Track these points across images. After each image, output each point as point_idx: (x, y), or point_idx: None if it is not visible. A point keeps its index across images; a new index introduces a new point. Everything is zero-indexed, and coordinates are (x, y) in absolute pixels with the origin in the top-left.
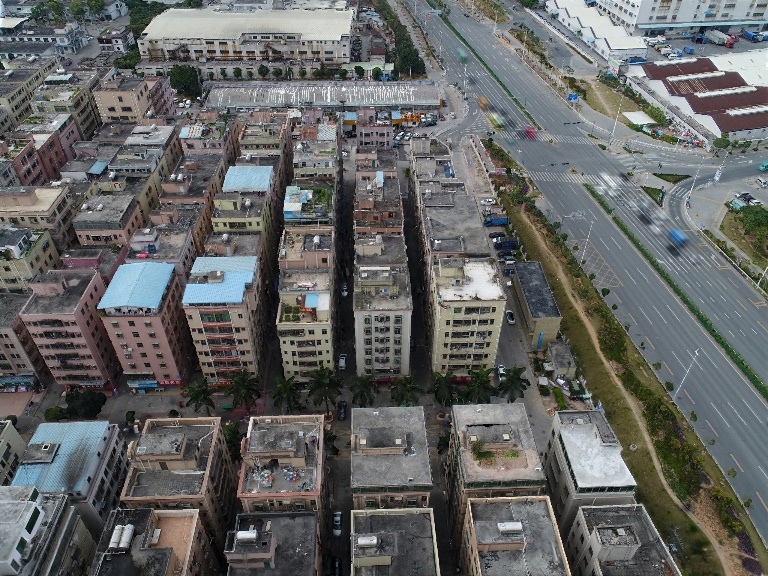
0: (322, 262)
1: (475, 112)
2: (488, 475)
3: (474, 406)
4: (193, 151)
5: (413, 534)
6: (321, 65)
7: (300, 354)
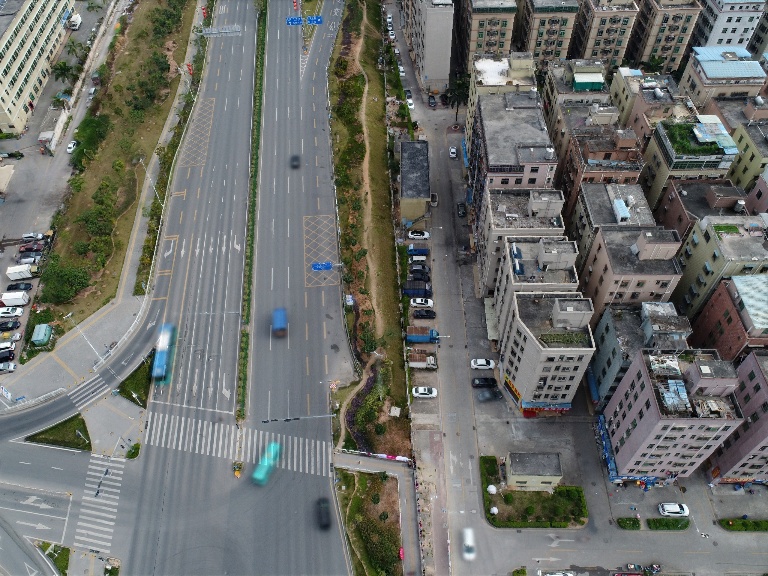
0: None
1: None
2: None
3: (504, 6)
4: None
5: None
6: None
7: None
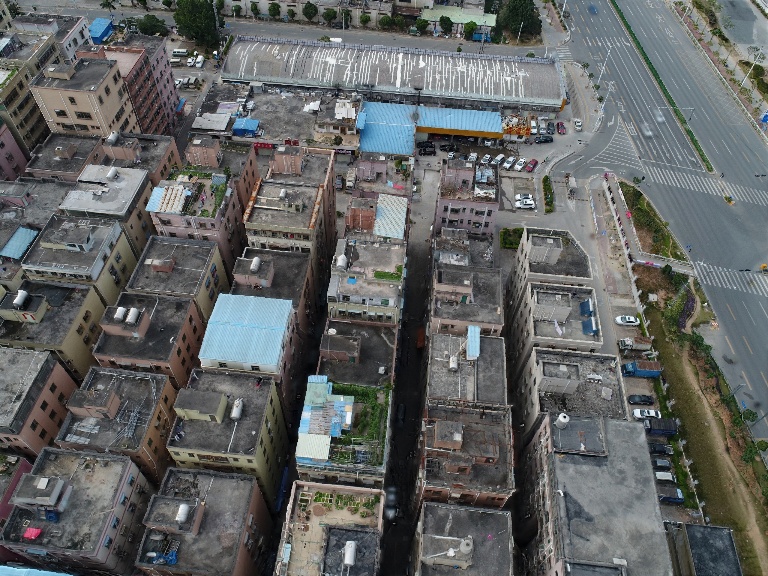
0: None
1: (611, 121)
2: None
3: None
4: (170, 228)
5: None
6: (392, 9)
7: None
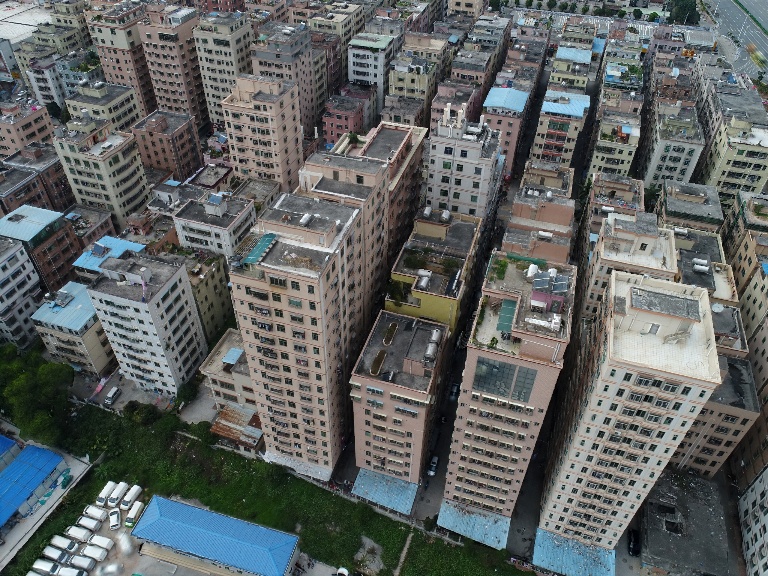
0: (633, 111)
1: (745, 58)
2: (764, 223)
3: (755, 194)
4: (524, 37)
5: (705, 243)
6: (603, 5)
7: (604, 170)
